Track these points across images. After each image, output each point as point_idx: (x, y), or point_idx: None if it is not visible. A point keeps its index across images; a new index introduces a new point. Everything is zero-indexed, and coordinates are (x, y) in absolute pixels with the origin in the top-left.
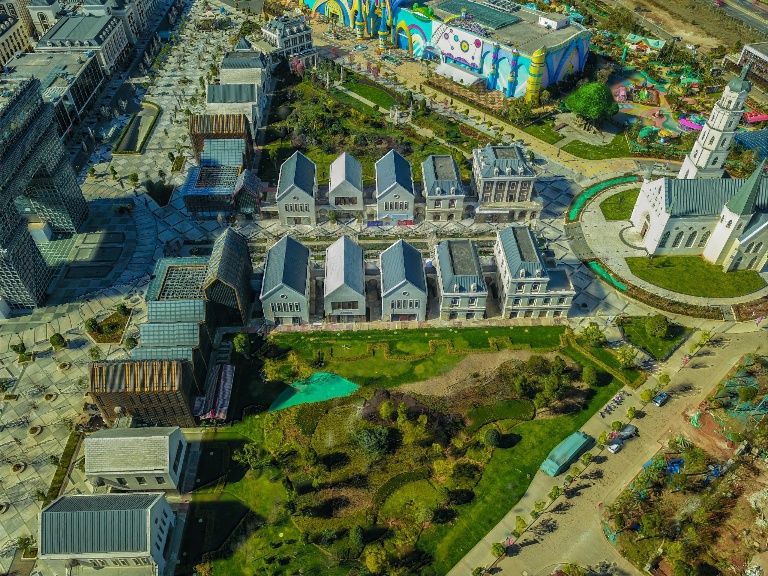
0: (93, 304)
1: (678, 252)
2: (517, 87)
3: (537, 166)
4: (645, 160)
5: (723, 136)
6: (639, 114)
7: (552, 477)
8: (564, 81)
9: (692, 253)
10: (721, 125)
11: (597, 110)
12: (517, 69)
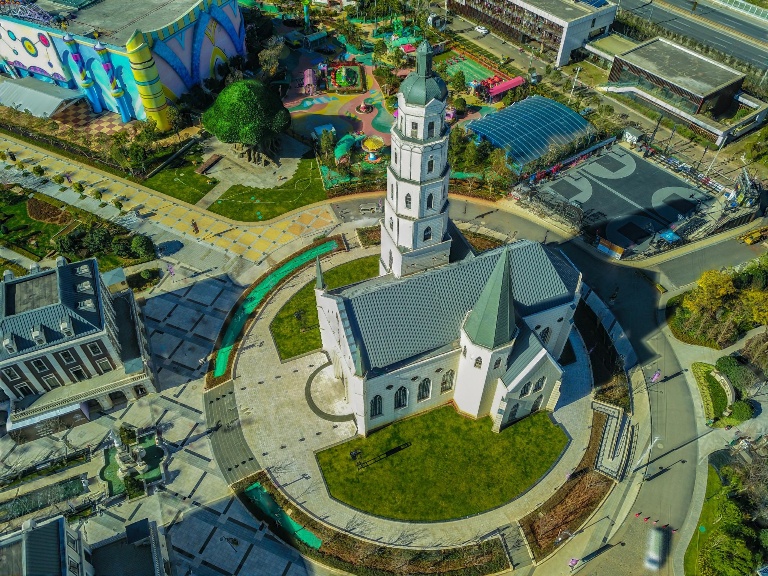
0: None
1: (410, 411)
2: (133, 104)
3: (163, 259)
4: (348, 200)
5: (424, 191)
6: (337, 112)
7: None
8: (211, 78)
9: (435, 404)
10: (413, 172)
11: (251, 130)
12: (119, 75)
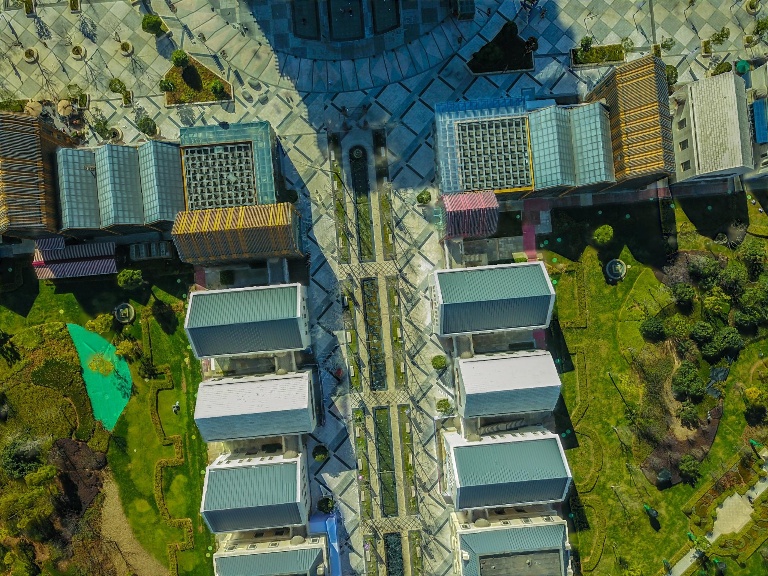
0: (238, 41)
1: None
2: None
3: None
4: None
5: None
6: None
7: None
8: None
9: None
10: None
11: None
12: None
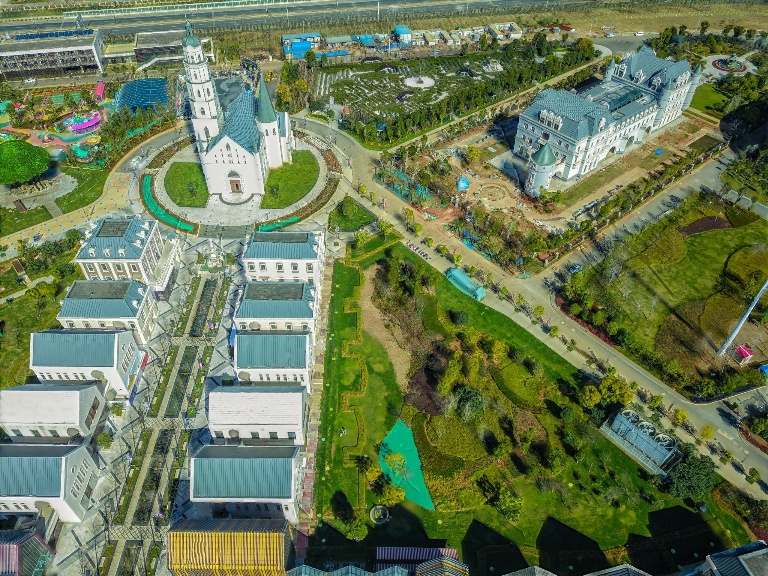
0: None
1: None
2: None
3: None
4: (120, 166)
5: (212, 83)
6: None
7: (486, 296)
8: None
9: (268, 172)
10: (206, 76)
11: (41, 162)
12: None
